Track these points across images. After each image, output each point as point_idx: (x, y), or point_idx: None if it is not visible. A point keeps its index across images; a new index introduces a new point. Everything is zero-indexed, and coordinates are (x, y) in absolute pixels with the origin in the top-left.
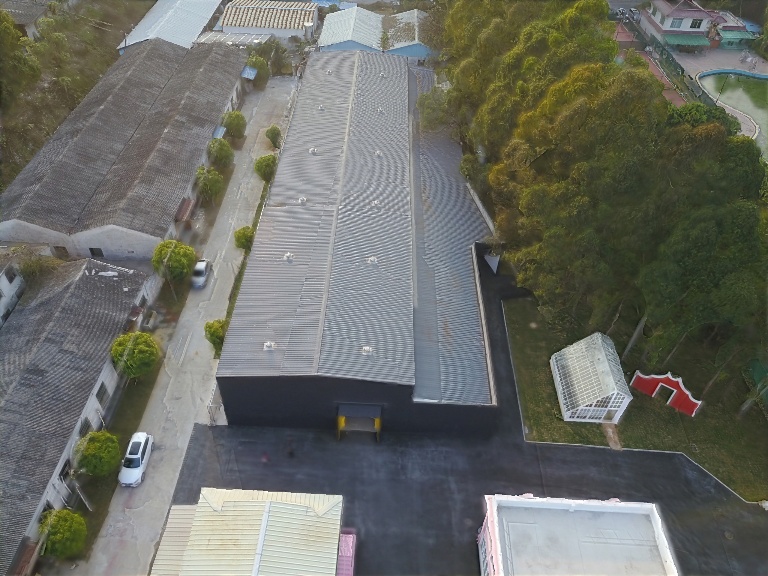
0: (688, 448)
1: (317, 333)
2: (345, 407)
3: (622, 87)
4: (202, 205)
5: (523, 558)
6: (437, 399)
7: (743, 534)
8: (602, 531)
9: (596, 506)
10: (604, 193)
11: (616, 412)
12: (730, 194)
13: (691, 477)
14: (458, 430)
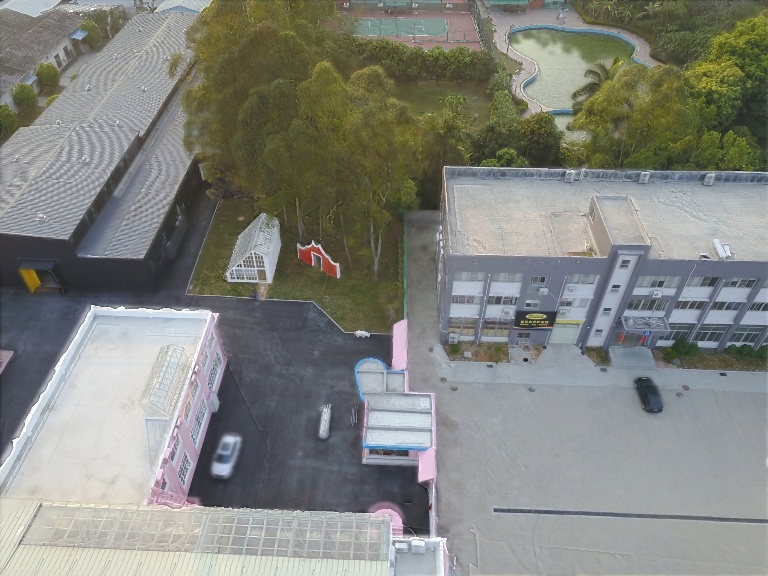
0: (321, 299)
1: (6, 206)
2: (26, 263)
3: (216, 1)
4: (2, 138)
5: (95, 345)
6: (99, 255)
7: (329, 352)
8: (166, 329)
9: (168, 313)
10: (212, 86)
11: (265, 272)
12: (277, 76)
13: (310, 317)
14: (128, 284)
